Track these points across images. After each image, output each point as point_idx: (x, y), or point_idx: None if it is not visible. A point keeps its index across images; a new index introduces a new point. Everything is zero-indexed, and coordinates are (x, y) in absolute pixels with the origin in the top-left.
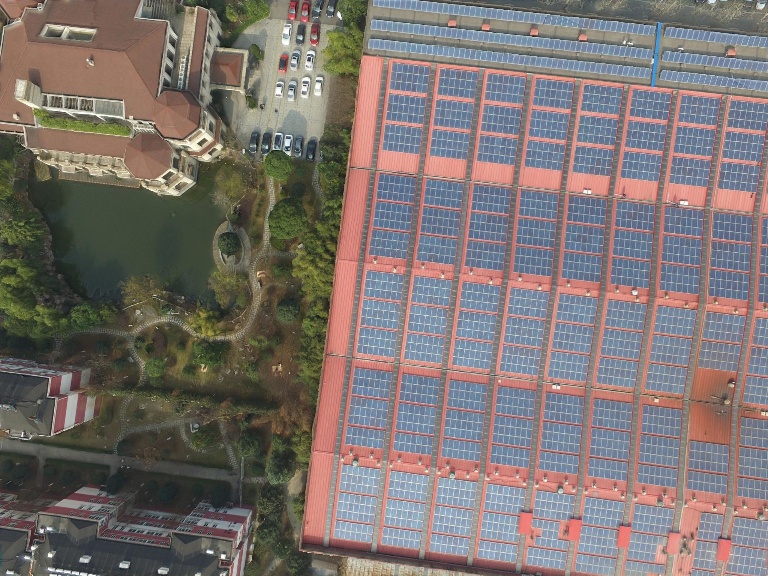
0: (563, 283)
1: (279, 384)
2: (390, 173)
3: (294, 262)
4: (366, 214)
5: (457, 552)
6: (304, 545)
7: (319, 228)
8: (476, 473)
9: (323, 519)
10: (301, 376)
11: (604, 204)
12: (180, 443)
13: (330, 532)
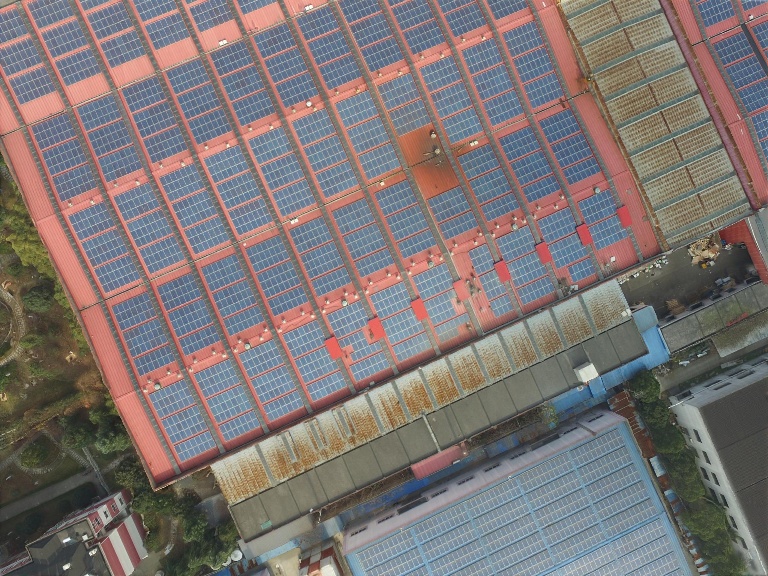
0: (246, 130)
1: (82, 370)
2: (41, 121)
3: (16, 252)
4: (39, 169)
5: (293, 408)
6: (159, 485)
7: (17, 209)
8: (267, 332)
9: (162, 452)
10: (82, 347)
11: (243, 45)
12: (23, 476)
13: (175, 459)
